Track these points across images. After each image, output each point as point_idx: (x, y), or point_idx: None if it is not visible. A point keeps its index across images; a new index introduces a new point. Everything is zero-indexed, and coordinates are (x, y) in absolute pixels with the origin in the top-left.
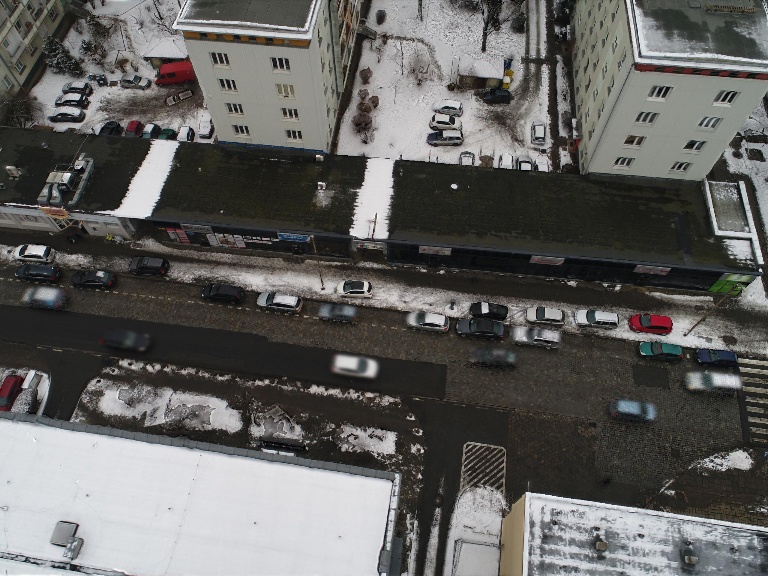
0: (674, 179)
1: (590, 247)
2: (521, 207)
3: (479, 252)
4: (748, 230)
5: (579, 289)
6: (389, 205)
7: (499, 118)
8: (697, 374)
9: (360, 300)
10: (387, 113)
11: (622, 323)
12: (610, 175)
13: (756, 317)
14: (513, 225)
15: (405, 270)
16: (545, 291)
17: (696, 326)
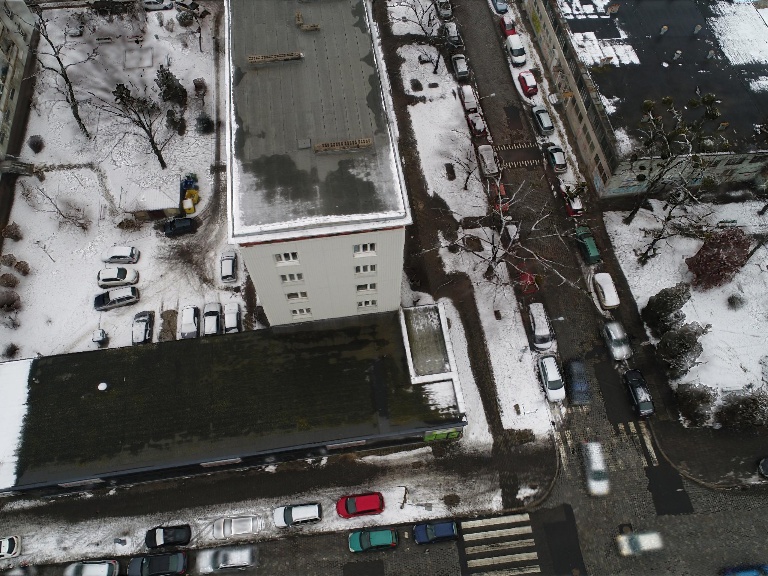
0: (368, 314)
1: (270, 435)
2: (189, 395)
3: (136, 473)
4: (449, 368)
5: (279, 474)
6: (20, 432)
7: (184, 254)
8: (416, 558)
9: (6, 561)
10: (45, 277)
11: (330, 509)
12: (295, 324)
13: (479, 461)
14: (177, 425)
15: (65, 501)
16: (239, 488)
17: (414, 491)
